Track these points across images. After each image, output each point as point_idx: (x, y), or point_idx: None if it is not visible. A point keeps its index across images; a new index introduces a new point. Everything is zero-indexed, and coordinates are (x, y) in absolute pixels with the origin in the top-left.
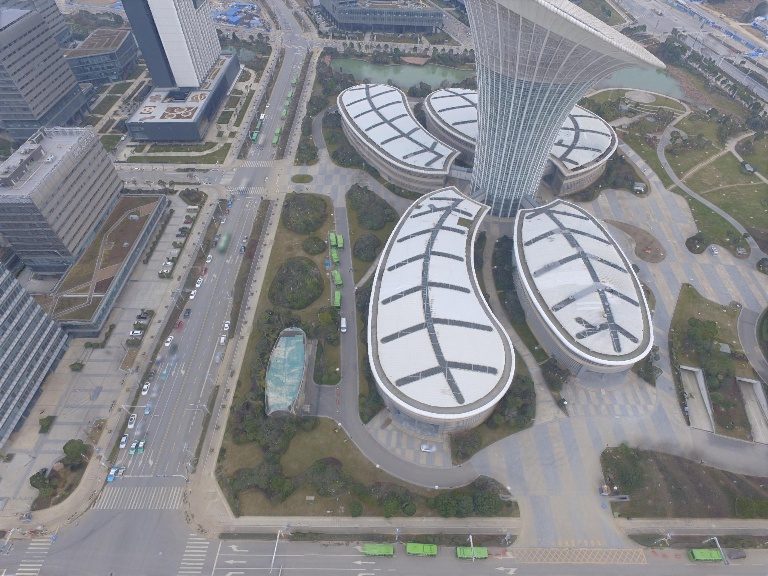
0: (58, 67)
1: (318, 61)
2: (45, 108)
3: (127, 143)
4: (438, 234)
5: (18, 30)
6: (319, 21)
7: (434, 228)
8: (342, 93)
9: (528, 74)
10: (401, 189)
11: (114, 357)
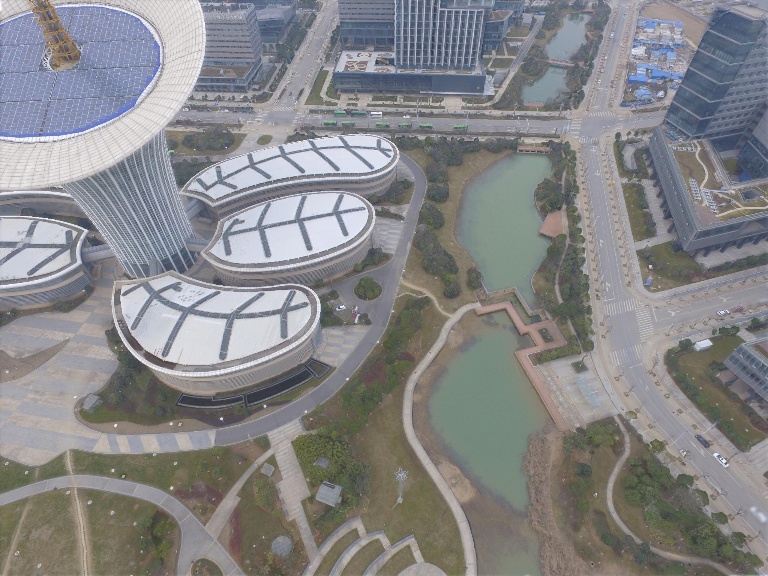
0: (386, 3)
1: None
2: (353, 19)
3: None
4: None
5: None
6: None
7: None
8: (376, 136)
9: None
10: None
11: None
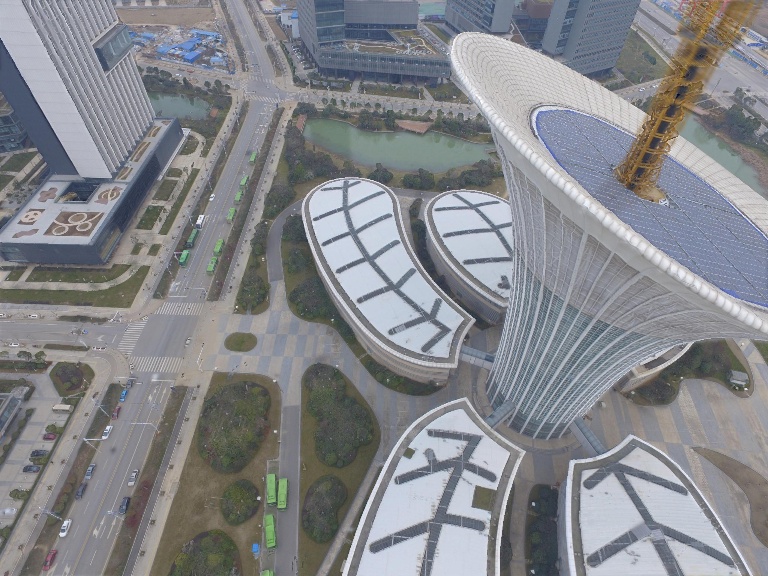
0: None
1: (288, 125)
2: None
3: (1, 262)
4: (440, 538)
5: None
6: (297, 60)
7: (433, 520)
8: (310, 194)
9: (623, 321)
10: (385, 373)
11: None
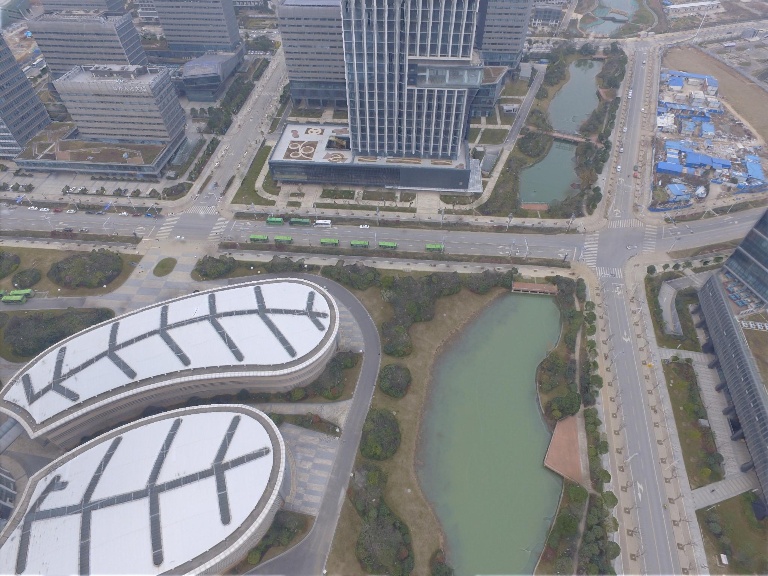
0: None
1: None
2: (305, 78)
3: None
4: None
5: (316, 13)
6: None
7: None
8: (310, 283)
9: None
10: None
11: (1, 182)
